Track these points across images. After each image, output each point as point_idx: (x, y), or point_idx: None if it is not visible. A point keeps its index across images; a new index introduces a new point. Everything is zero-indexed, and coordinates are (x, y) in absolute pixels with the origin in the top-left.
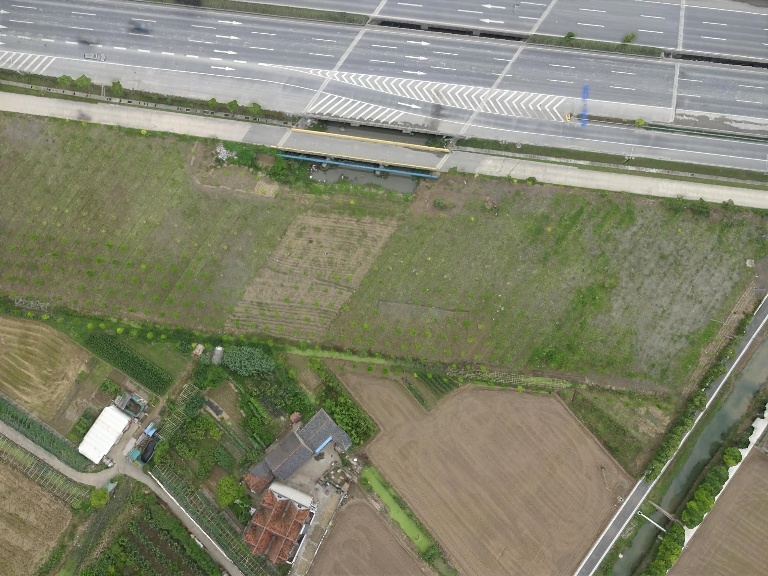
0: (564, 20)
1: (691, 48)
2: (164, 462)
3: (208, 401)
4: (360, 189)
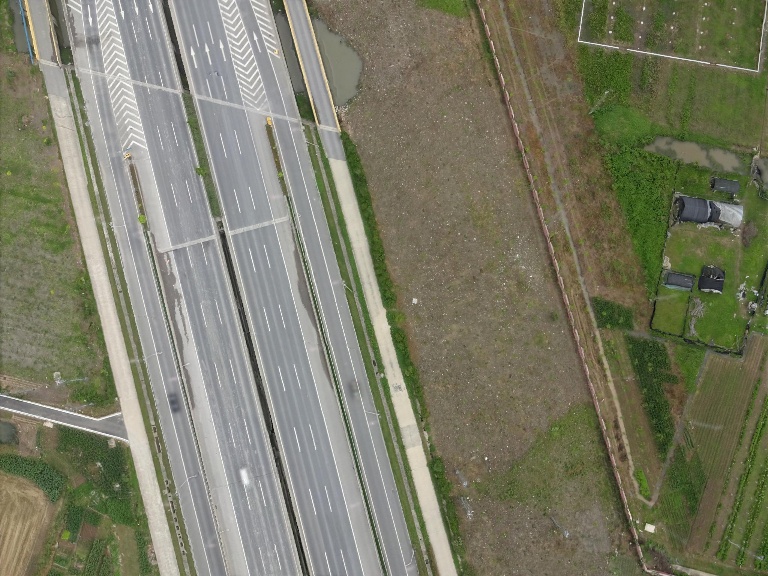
0: (219, 120)
1: (235, 243)
2: None
3: None
4: (4, 5)
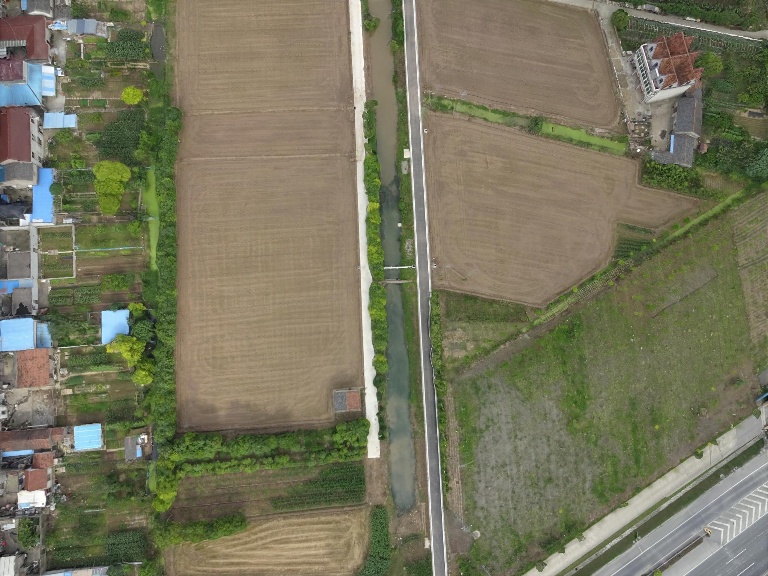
0: None
1: None
2: (759, 54)
3: (763, 116)
4: None
